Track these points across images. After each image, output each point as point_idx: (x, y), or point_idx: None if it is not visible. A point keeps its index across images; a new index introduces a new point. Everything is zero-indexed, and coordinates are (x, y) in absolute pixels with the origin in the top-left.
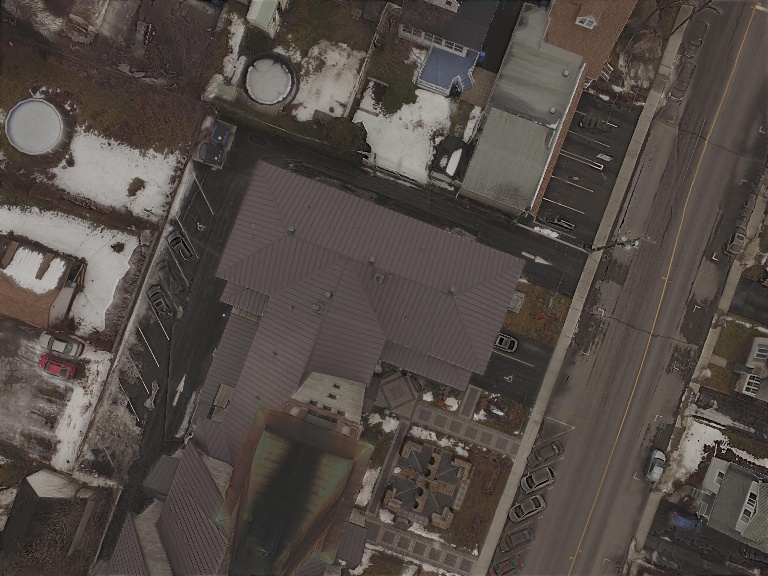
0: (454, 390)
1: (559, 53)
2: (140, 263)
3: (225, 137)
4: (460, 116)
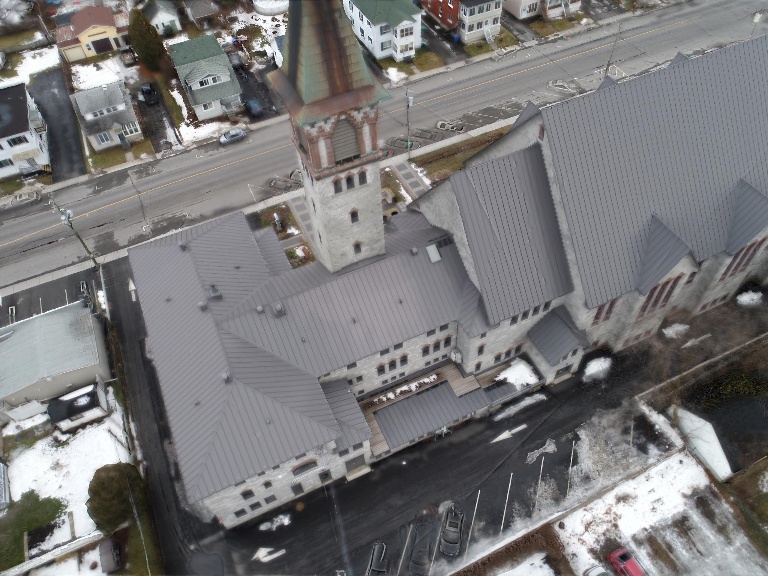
0: (290, 257)
1: None
2: None
3: None
4: (24, 440)
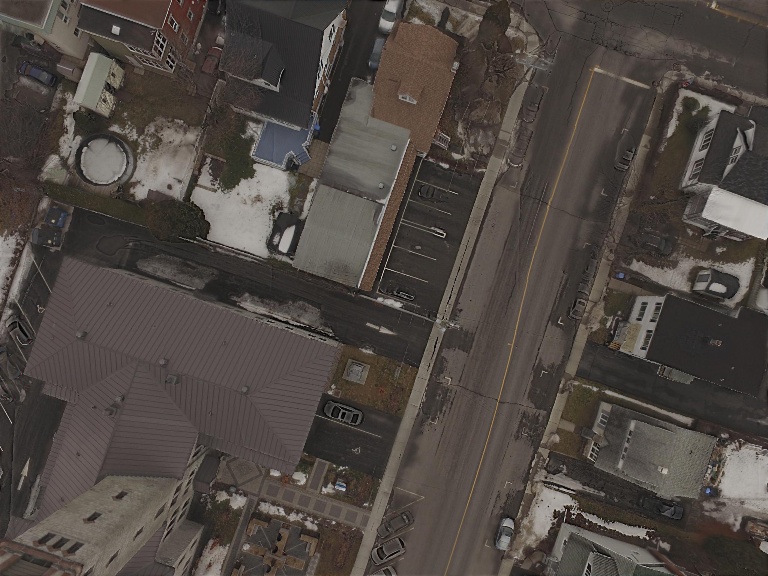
0: (301, 464)
1: (387, 127)
2: None
3: (61, 219)
4: (299, 189)
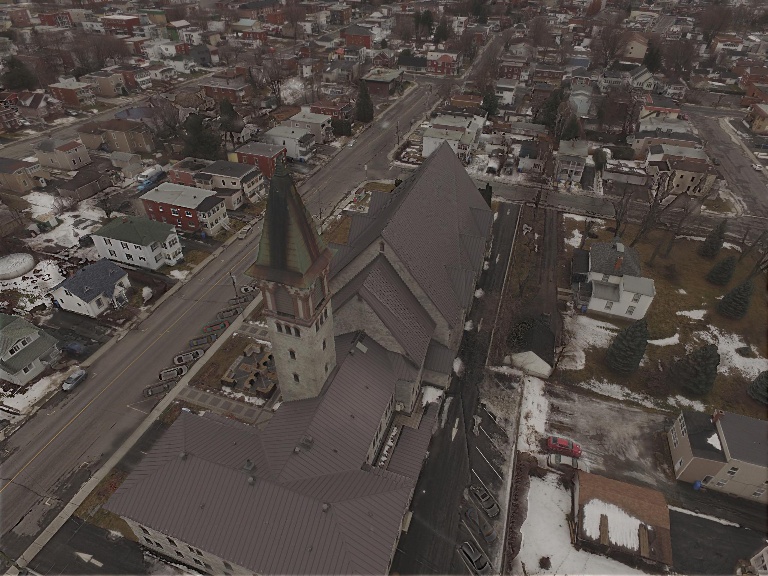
0: None
1: None
2: (511, 536)
3: None
4: None
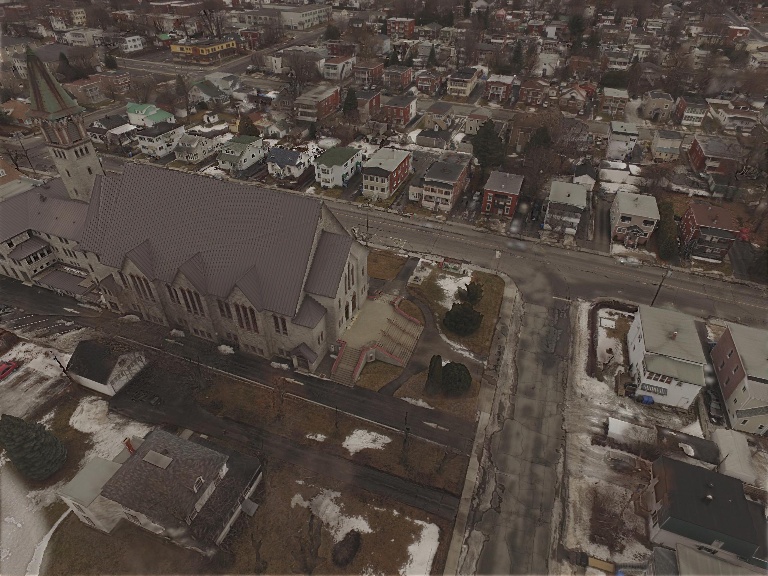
0: None
1: (8, 184)
2: None
3: None
4: None
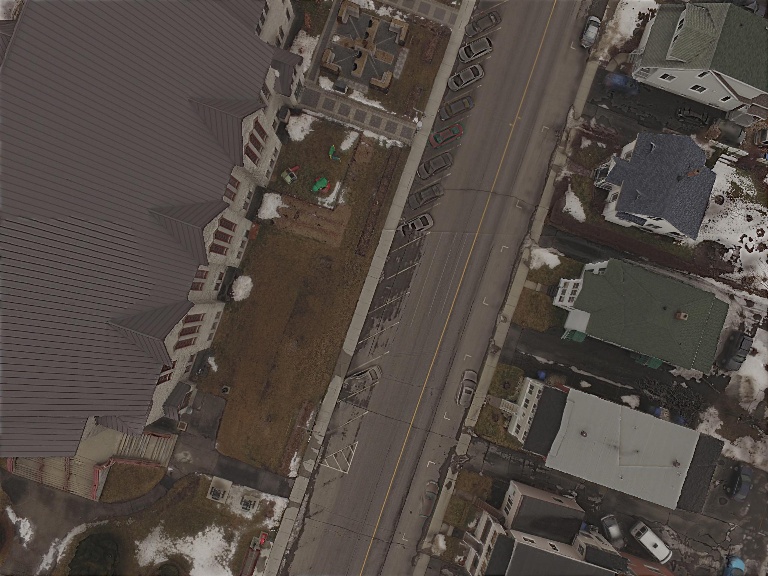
0: None
1: None
2: None
3: None
4: None
